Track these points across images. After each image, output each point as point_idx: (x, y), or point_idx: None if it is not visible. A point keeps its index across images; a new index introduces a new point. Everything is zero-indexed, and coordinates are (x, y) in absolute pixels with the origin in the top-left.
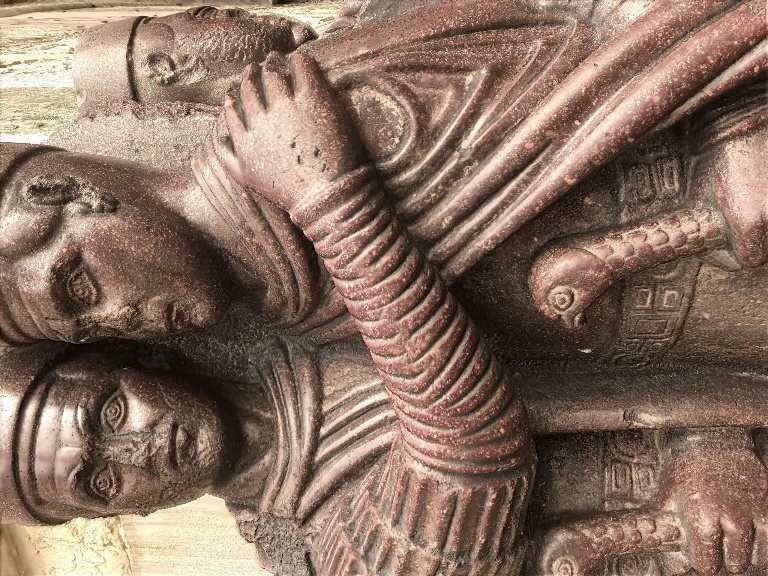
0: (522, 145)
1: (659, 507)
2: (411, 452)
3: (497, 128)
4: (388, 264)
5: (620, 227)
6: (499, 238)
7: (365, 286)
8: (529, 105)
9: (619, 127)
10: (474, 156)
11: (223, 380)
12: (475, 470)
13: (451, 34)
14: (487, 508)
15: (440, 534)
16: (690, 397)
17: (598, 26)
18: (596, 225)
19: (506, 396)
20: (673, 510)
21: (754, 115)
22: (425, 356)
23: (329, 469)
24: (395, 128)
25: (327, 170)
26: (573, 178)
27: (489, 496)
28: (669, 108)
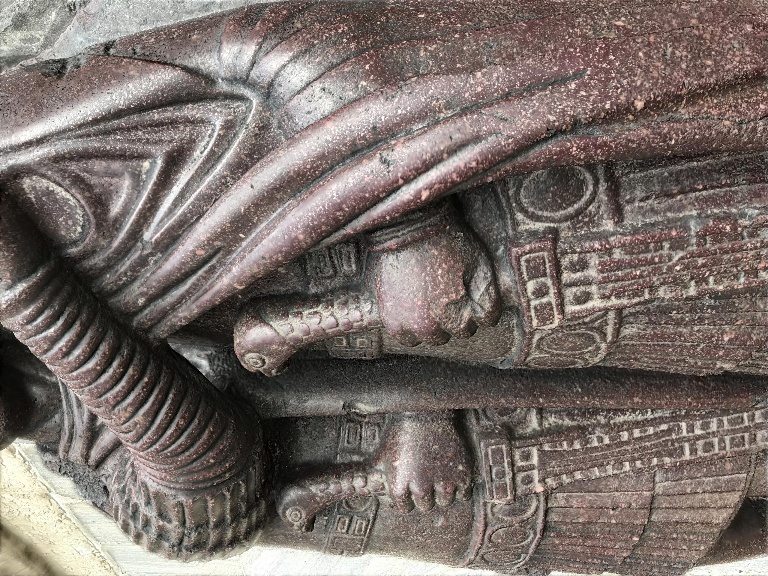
0: (194, 252)
1: (374, 465)
2: (143, 470)
3: (173, 226)
4: (80, 357)
5: (305, 301)
6: (190, 319)
7: (63, 373)
8: (203, 203)
9: (272, 254)
10: (155, 250)
11: (10, 342)
12: (193, 488)
13: (122, 114)
14: (210, 506)
15: (178, 519)
16: (399, 389)
17: (275, 112)
18: (291, 289)
19: (214, 434)
20: (382, 469)
21: (402, 236)
22: (130, 421)
23: (109, 432)
24: (75, 217)
25: (0, 280)
26: (242, 285)
27: (208, 501)
28: (315, 242)
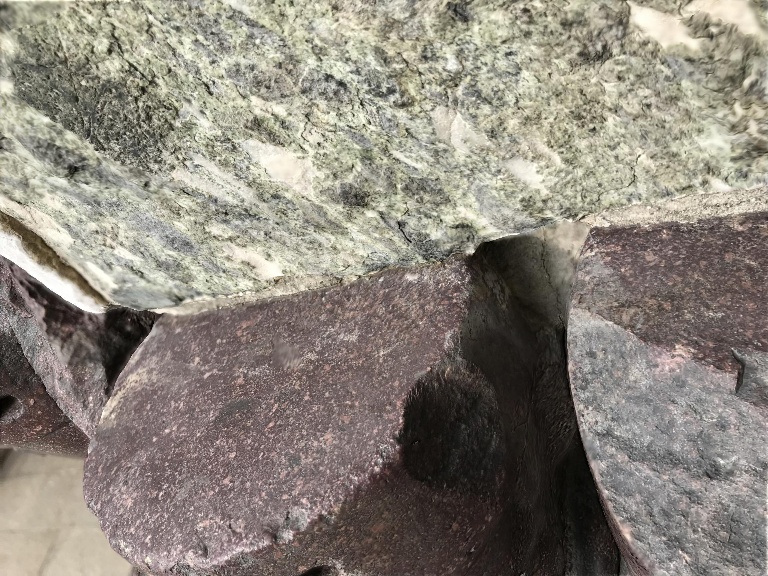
0: None
1: None
2: None
3: None
4: None
5: None
6: None
7: None
8: None
9: None
10: None
11: None
12: None
13: None
14: None
15: None
16: None
17: None
18: None
19: None
20: None
21: None
22: None
23: None
24: None
25: None
26: None
27: None
28: None
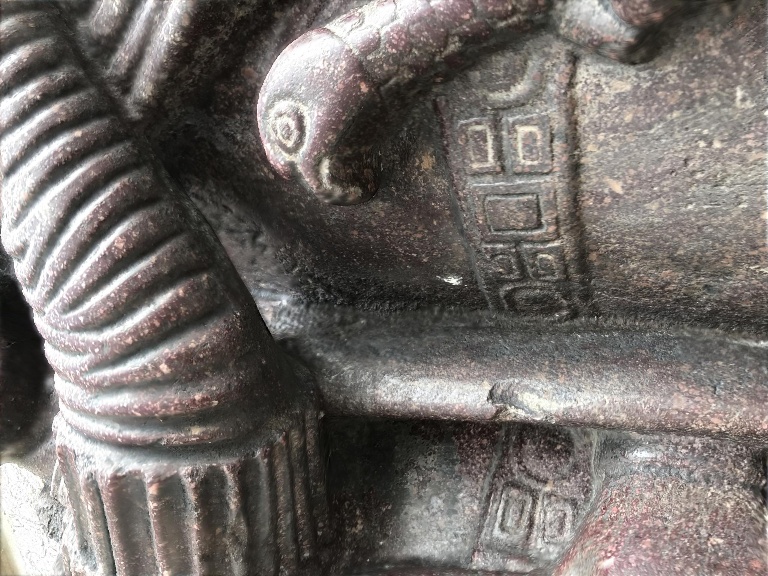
0: None
1: (552, 575)
2: None
3: None
4: None
5: None
6: (181, 17)
7: None
8: None
9: None
10: None
11: None
12: (119, 436)
13: None
14: (150, 512)
15: (100, 549)
16: (622, 370)
17: None
18: None
19: (183, 307)
20: None
21: None
22: (29, 217)
23: None
24: None
25: None
26: None
27: (146, 489)
28: None
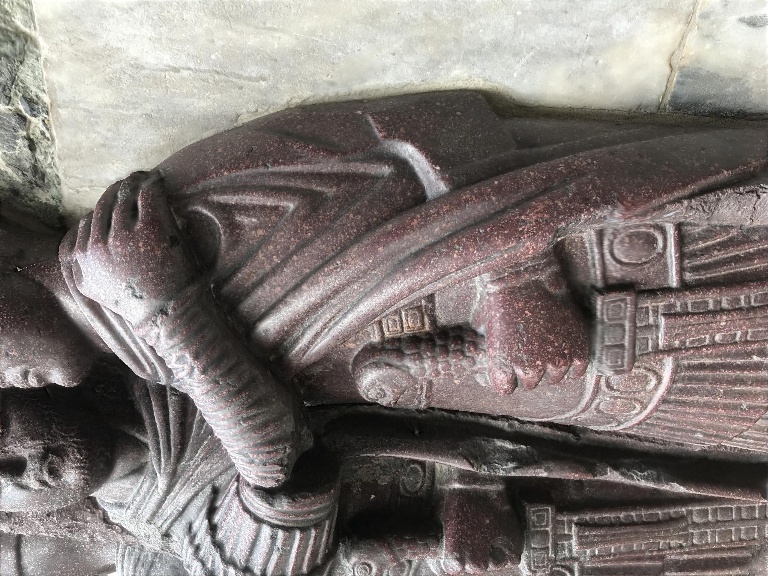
0: None
1: None
2: None
3: None
4: None
5: None
6: None
7: None
8: None
9: None
10: None
11: None
12: None
13: None
14: None
15: None
16: None
17: None
18: None
19: None
20: None
21: None
22: None
23: None
24: None
25: None
26: None
27: None
28: None
